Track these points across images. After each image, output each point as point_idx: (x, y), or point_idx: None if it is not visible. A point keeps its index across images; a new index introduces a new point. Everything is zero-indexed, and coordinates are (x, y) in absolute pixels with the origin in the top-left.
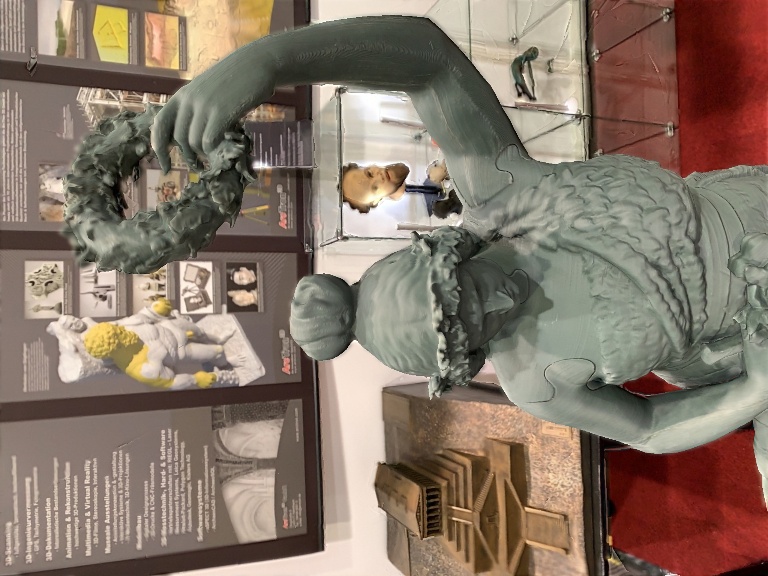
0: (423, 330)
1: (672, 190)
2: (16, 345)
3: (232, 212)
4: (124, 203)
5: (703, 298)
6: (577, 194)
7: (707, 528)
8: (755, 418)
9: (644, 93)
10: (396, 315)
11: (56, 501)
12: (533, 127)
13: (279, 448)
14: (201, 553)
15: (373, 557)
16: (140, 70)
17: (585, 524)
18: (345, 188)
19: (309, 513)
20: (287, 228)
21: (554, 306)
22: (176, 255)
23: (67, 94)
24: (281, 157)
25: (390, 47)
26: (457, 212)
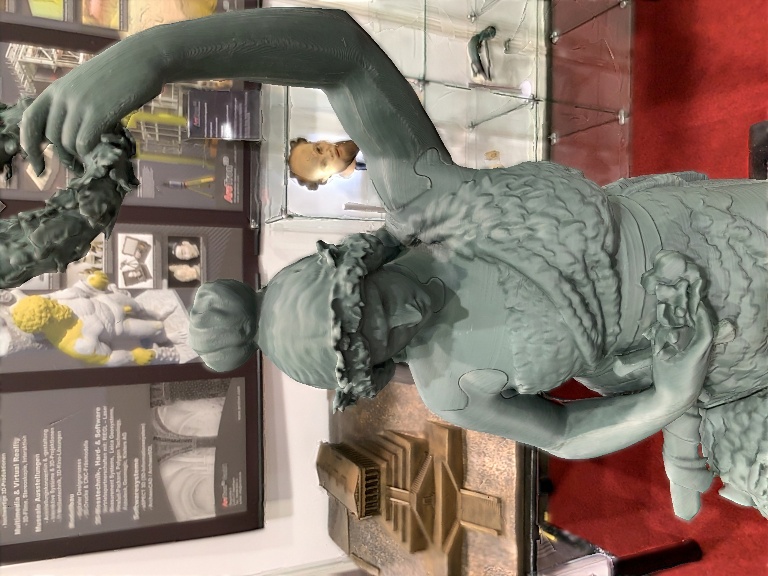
0: (323, 346)
1: (591, 203)
2: None
3: (105, 224)
4: None
5: (617, 311)
6: (495, 203)
7: (635, 506)
8: (664, 427)
9: (599, 78)
10: (296, 329)
11: None
12: (488, 108)
13: (220, 426)
14: (137, 531)
15: (314, 533)
16: (76, 28)
17: (516, 507)
18: (293, 164)
19: (249, 491)
20: (233, 202)
21: (469, 316)
22: (42, 269)
23: None
24: (227, 129)
25: (297, 43)
26: None
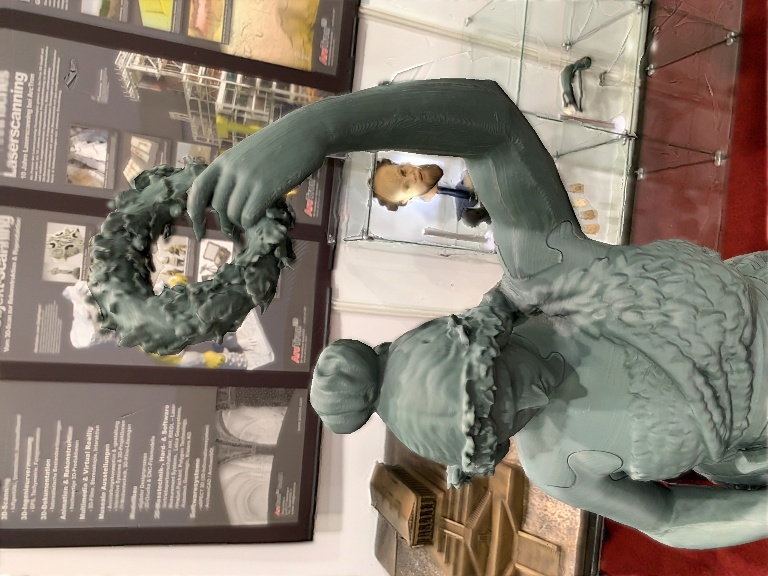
0: (451, 426)
1: (732, 292)
2: (31, 305)
3: (265, 301)
4: (152, 265)
5: (747, 406)
6: (629, 284)
7: (697, 567)
8: None
9: (694, 114)
10: (424, 405)
11: (56, 463)
12: (575, 138)
13: (280, 435)
14: (192, 529)
15: (360, 550)
16: (182, 39)
17: (577, 558)
18: (376, 184)
19: (302, 502)
20: (312, 216)
21: (588, 395)
22: (201, 339)
23: (106, 57)
24: None
25: (452, 119)
26: (487, 222)
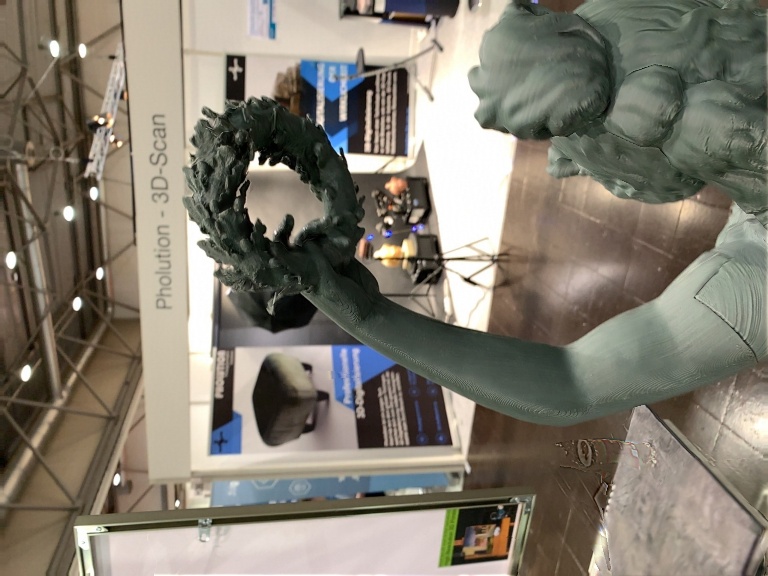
0: None
1: None
2: None
3: None
4: (246, 188)
5: None
6: None
7: None
8: None
9: None
10: None
11: None
12: None
13: None
14: None
15: None
16: None
17: None
18: None
19: None
20: None
21: None
22: None
23: None
24: None
25: None
26: None
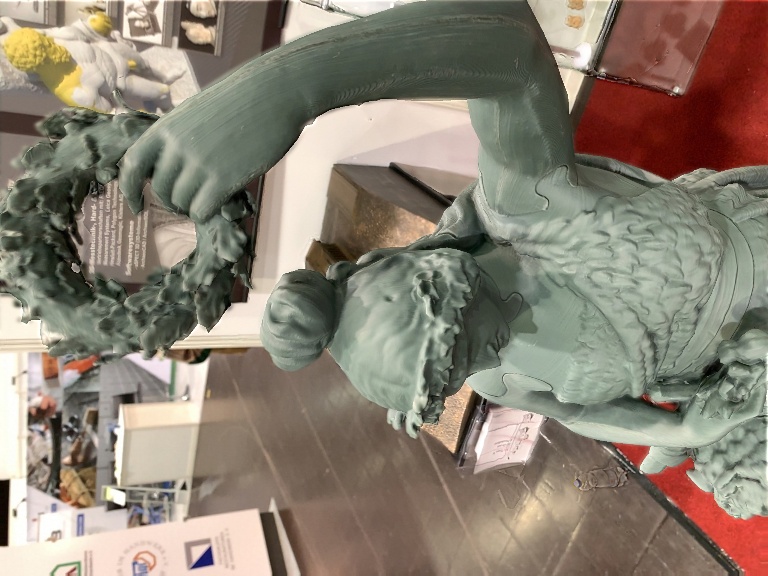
0: (402, 393)
1: (706, 263)
2: None
3: None
4: (77, 236)
5: (679, 355)
6: (609, 245)
7: None
8: None
9: None
10: (378, 370)
11: None
12: None
13: None
14: (128, 285)
15: None
16: None
17: None
18: None
19: None
20: None
21: (537, 333)
22: None
23: None
24: None
25: (464, 72)
26: None
